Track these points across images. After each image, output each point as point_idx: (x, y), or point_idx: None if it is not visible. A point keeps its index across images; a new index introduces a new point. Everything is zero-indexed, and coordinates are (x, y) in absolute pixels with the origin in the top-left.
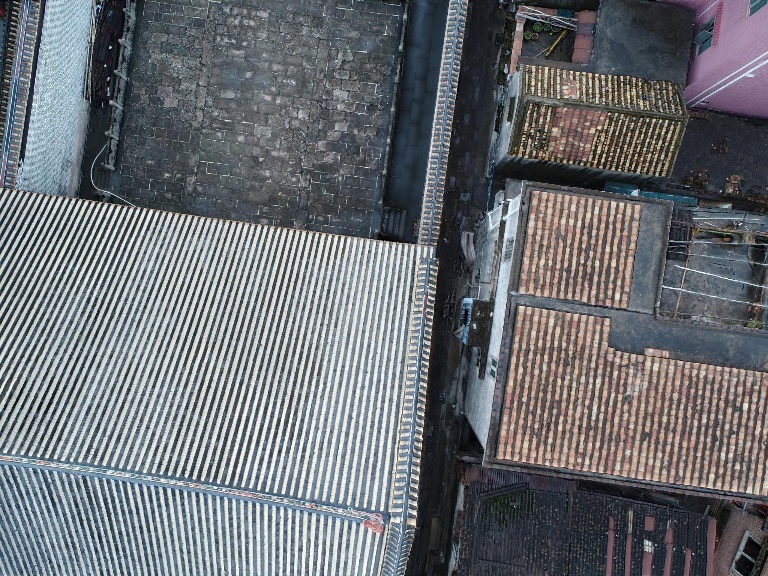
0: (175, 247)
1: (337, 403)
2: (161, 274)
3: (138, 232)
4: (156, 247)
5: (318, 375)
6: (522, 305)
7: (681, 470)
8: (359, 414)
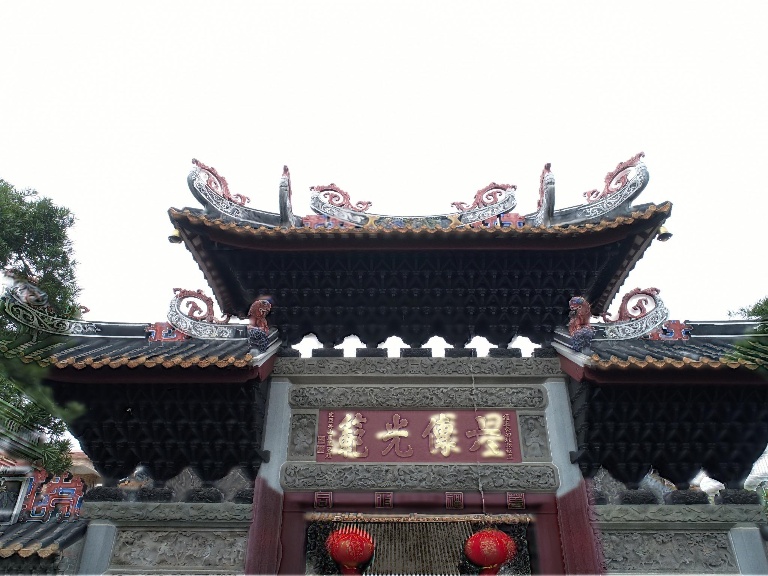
0: None
1: None
2: None
3: None
4: None
5: None
6: None
7: None
8: None
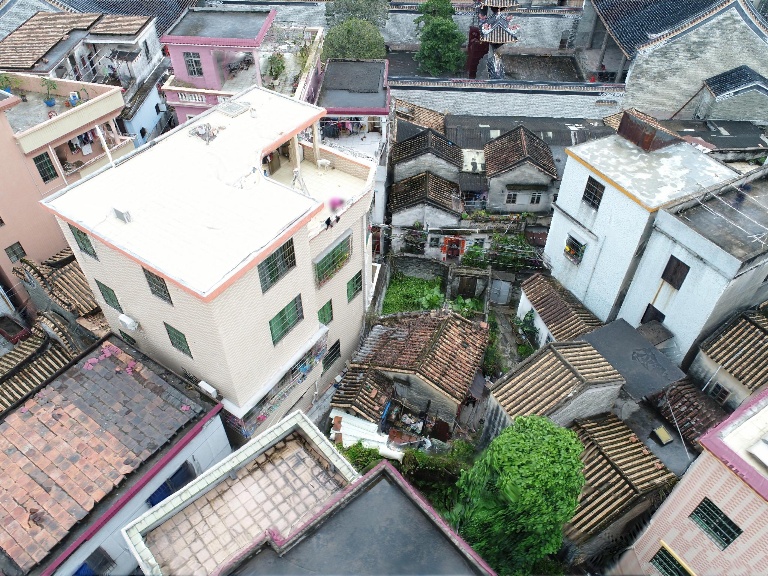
0: (170, 7)
1: (84, 3)
2: (158, 0)
3: (180, 4)
4: (171, 4)
5: (98, 6)
6: (103, 16)
7: (7, 42)
8: (76, 4)
